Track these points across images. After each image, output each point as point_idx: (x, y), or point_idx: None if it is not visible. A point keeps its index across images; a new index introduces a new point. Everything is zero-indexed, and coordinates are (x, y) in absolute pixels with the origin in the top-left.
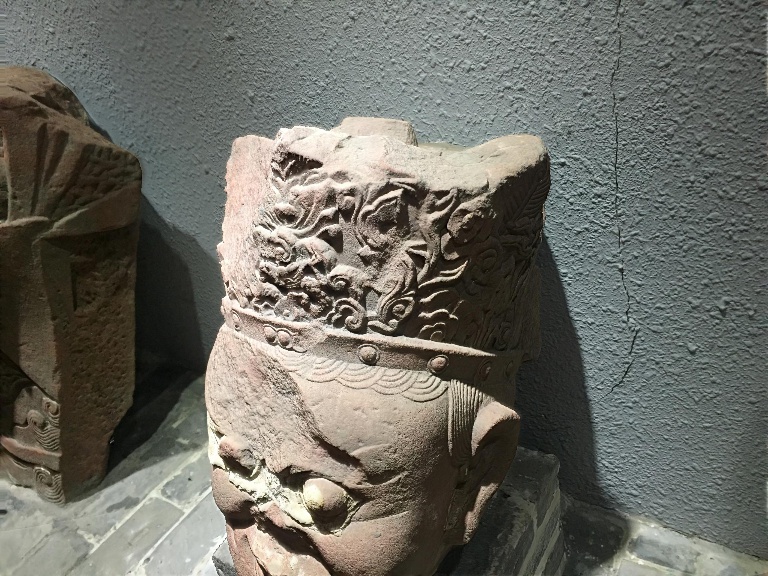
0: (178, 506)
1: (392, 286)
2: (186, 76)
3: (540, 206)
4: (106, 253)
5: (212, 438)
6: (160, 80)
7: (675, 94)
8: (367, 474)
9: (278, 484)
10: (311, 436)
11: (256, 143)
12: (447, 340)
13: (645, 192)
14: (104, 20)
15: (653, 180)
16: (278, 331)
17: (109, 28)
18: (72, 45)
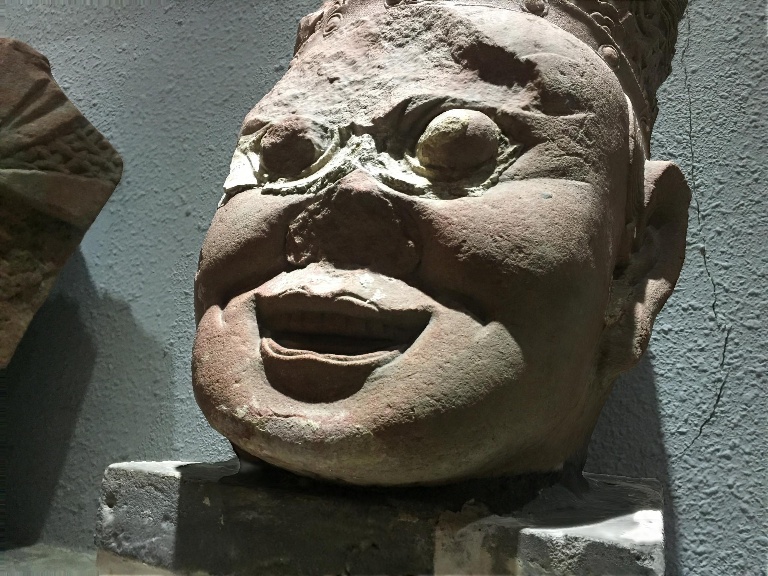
0: None
1: None
2: (210, 111)
3: (679, 16)
4: (31, 243)
5: (240, 162)
6: (176, 119)
7: (745, 61)
8: (543, 90)
9: (372, 145)
10: (453, 59)
11: None
12: None
13: (724, 157)
14: (138, 69)
15: (731, 144)
16: None
17: (140, 76)
18: (84, 97)
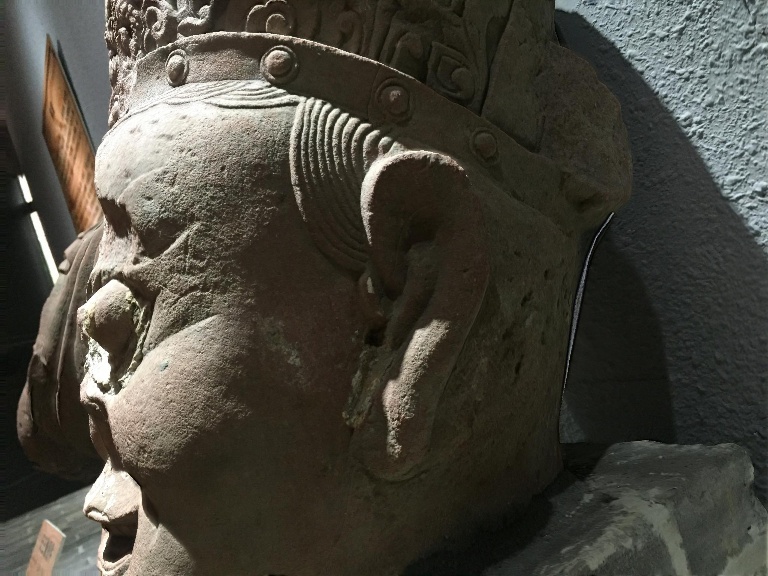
0: None
1: None
2: None
3: None
4: None
5: None
6: None
7: None
8: (138, 233)
9: None
10: None
11: None
12: (301, 37)
13: None
14: None
15: None
16: None
17: None
18: None
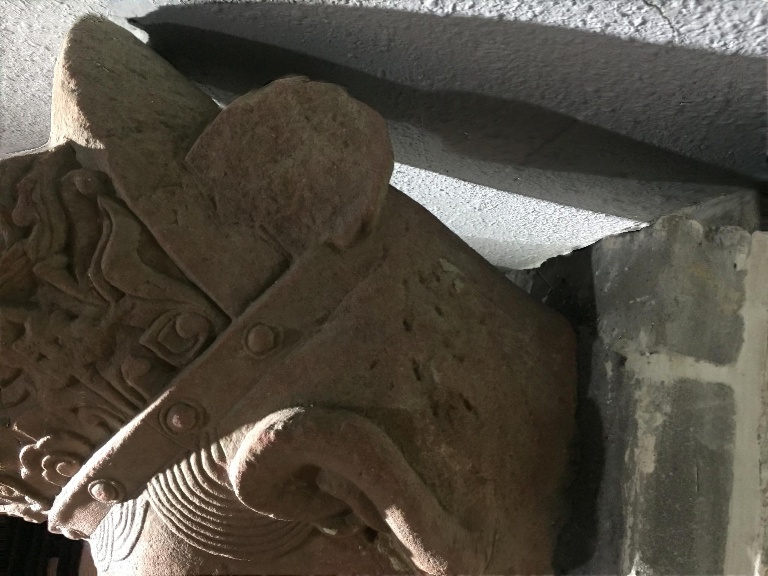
0: None
1: None
2: None
3: None
4: None
5: None
6: None
7: None
8: None
9: None
10: None
11: None
12: (87, 455)
13: None
14: None
15: None
16: None
17: None
18: None
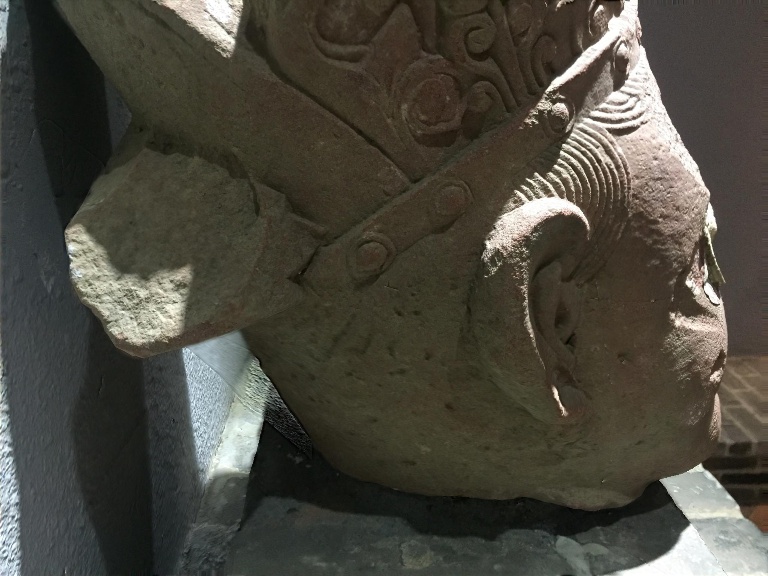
0: None
1: None
2: None
3: None
4: None
5: None
6: None
7: None
8: None
9: None
10: None
11: None
12: None
13: None
14: None
15: None
16: None
17: None
18: None
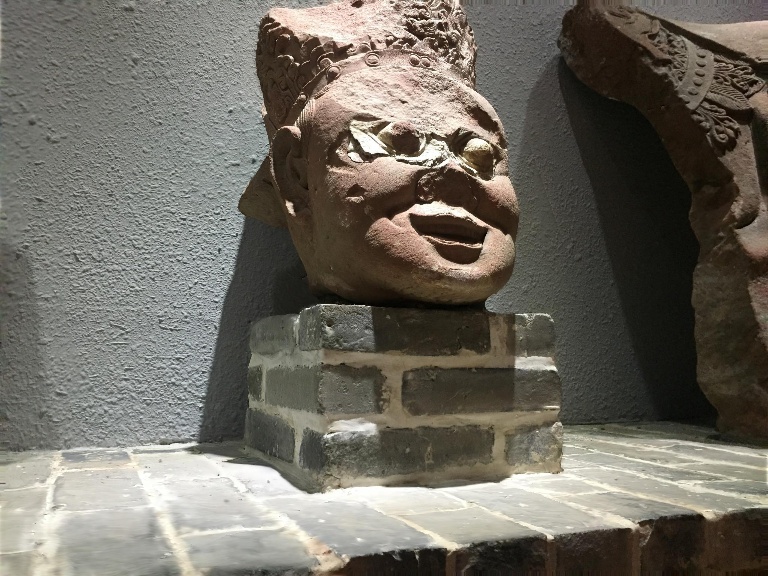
0: (24, 487)
1: (468, 56)
2: (50, 26)
3: None
4: None
5: (366, 137)
6: (3, 21)
7: None
8: (500, 137)
9: (448, 148)
10: (466, 111)
11: (299, 11)
12: None
13: None
14: None
15: None
16: (422, 58)
17: None
18: None
